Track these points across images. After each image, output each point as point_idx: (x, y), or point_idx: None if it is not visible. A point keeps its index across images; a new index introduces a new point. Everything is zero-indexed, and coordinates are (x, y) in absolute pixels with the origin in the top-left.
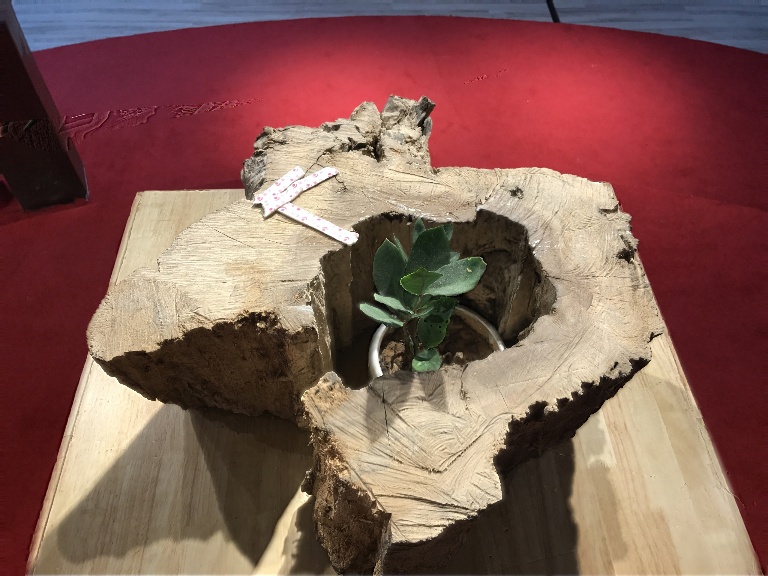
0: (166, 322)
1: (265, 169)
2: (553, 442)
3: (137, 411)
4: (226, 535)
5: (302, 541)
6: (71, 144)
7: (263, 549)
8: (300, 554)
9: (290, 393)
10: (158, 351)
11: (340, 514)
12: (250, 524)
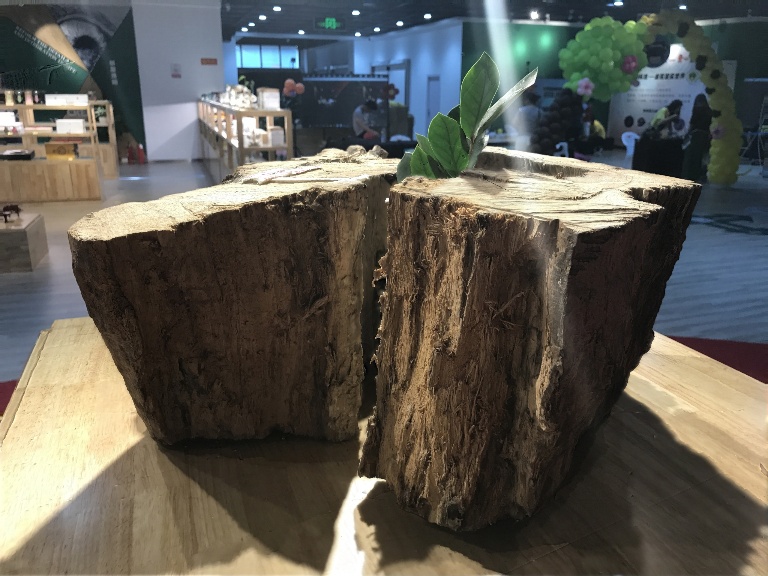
0: (177, 216)
1: (243, 176)
2: (637, 346)
3: (83, 464)
4: (262, 549)
5: (380, 532)
6: (54, 76)
7: (326, 552)
8: (384, 545)
9: (318, 355)
10: (171, 236)
11: (471, 318)
12: (295, 532)
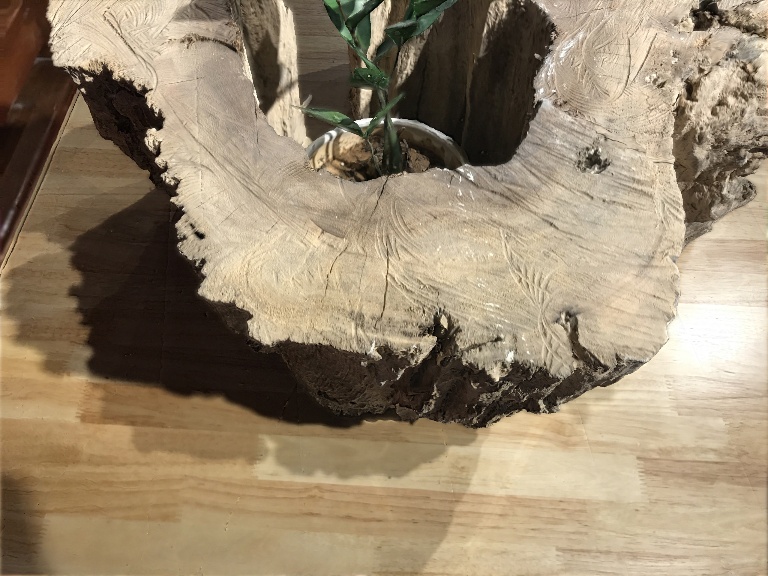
0: None
1: None
2: None
3: None
4: None
5: None
6: None
7: None
8: None
9: None
10: None
11: None
12: None
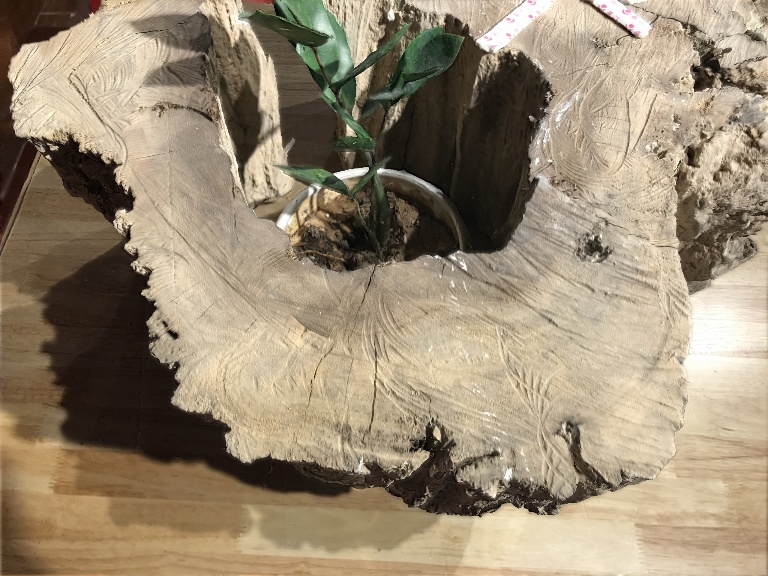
0: None
1: None
2: None
3: None
4: None
5: None
6: None
7: None
8: None
9: None
10: None
11: None
12: None
